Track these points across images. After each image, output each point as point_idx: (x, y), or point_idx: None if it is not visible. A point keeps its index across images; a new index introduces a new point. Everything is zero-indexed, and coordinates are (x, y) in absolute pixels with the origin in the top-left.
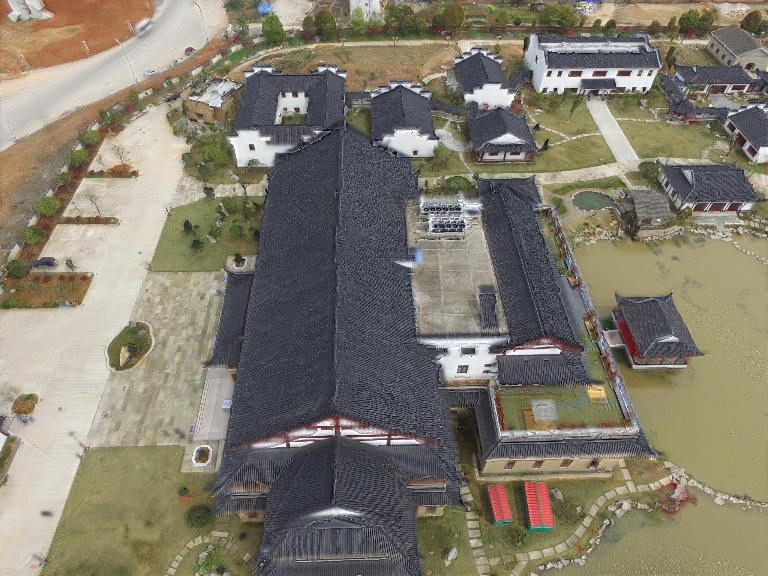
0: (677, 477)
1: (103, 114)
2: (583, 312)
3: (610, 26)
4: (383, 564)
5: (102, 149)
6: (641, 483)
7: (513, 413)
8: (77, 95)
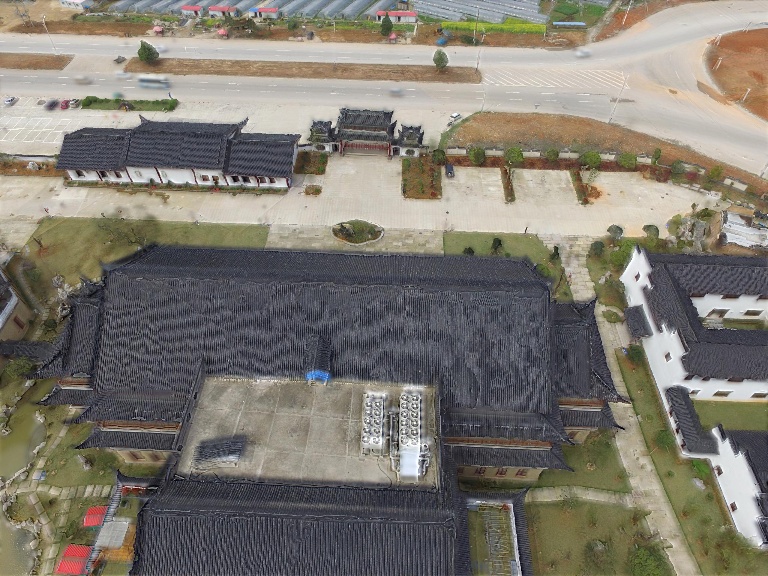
0: None
1: (656, 154)
2: None
3: None
4: None
5: (619, 174)
6: None
7: None
8: (710, 141)
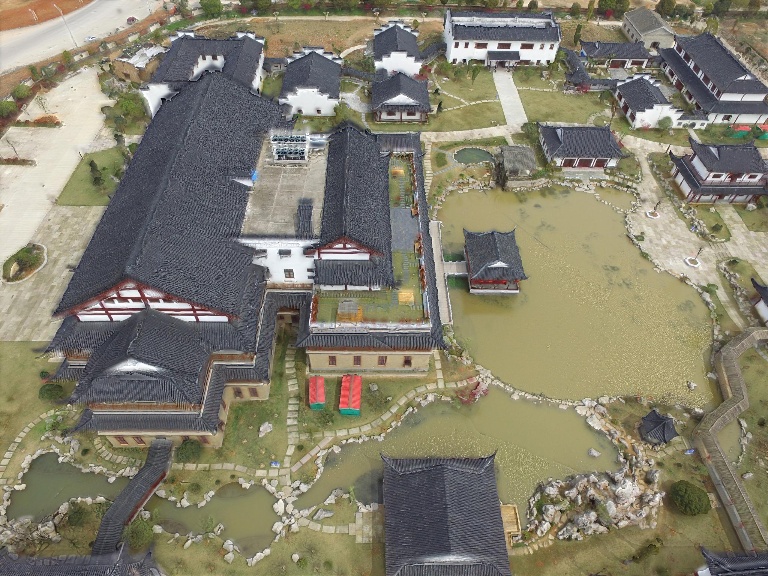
0: (483, 377)
1: (34, 70)
2: (416, 236)
3: (532, 6)
4: (185, 418)
5: (33, 103)
6: (450, 381)
7: (328, 310)
8: (19, 57)
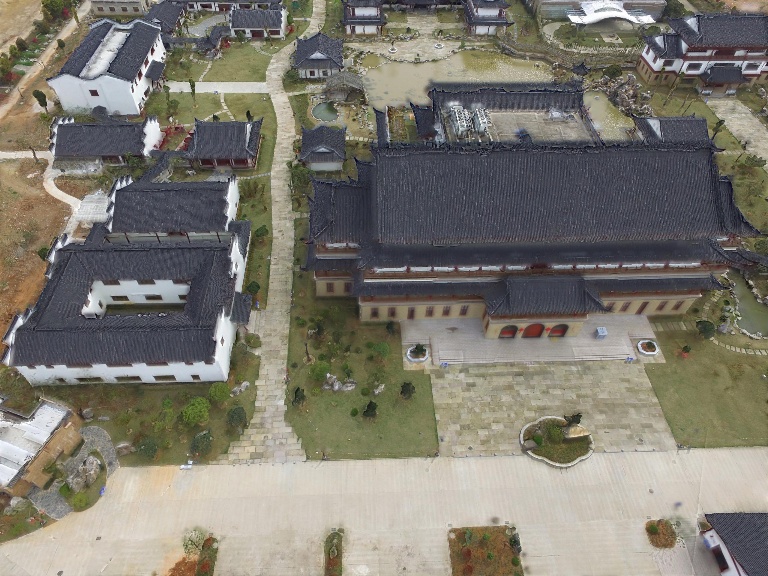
0: None
1: None
2: None
3: (25, 46)
4: None
5: None
6: None
7: None
8: None
